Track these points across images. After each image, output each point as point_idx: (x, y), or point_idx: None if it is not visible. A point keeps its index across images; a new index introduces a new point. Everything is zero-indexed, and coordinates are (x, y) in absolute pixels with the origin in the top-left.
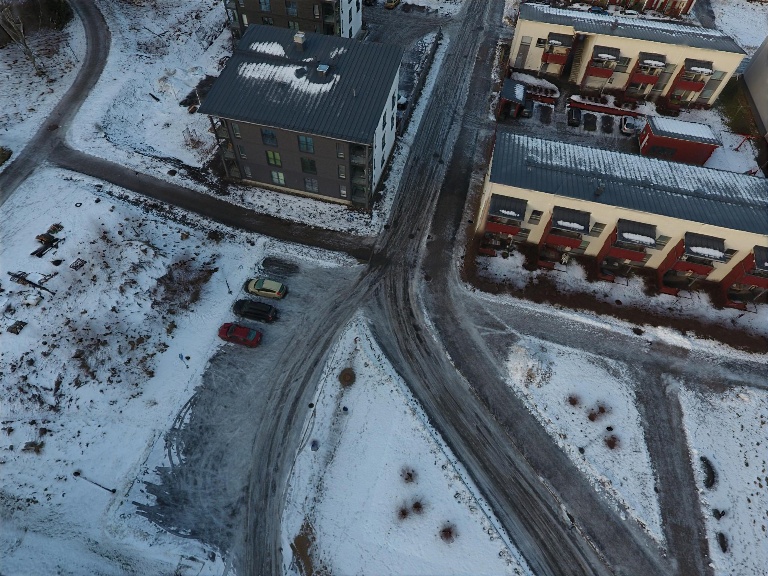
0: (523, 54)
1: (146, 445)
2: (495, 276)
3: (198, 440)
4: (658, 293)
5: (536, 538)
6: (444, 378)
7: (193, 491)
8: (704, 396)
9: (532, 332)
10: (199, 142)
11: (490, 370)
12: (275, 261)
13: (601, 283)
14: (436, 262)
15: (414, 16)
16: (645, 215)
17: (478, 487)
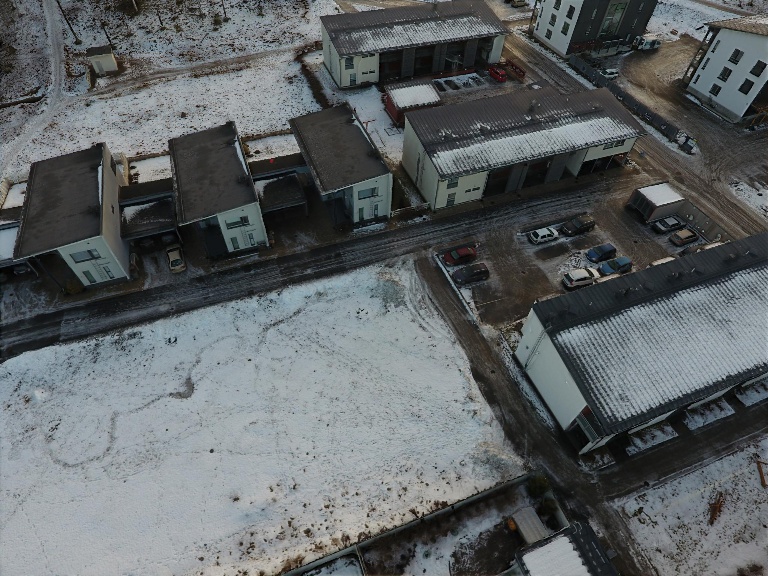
0: None
1: None
2: None
3: None
4: None
5: None
6: None
7: None
8: None
9: None
10: None
11: None
12: None
13: None
14: None
15: (749, 164)
16: None
17: None
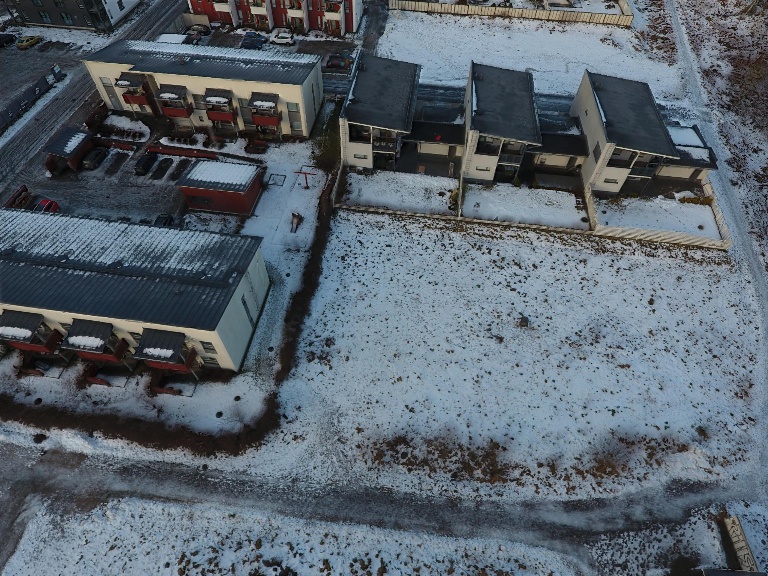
0: (113, 95)
1: None
2: None
3: None
4: (89, 384)
5: None
6: None
7: None
8: (61, 520)
9: None
10: None
11: None
12: None
13: (29, 378)
14: None
15: (47, 56)
16: None
17: None
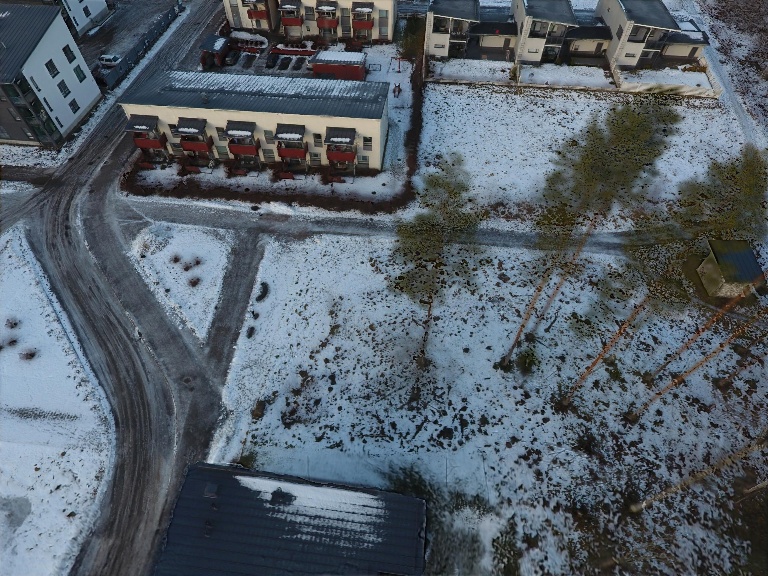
0: (236, 15)
1: None
2: (151, 183)
3: None
4: (280, 179)
5: (105, 350)
6: (76, 258)
7: None
8: (287, 244)
9: (165, 218)
10: None
11: (117, 248)
12: None
13: None
14: (103, 179)
15: None
16: (240, 114)
17: (72, 325)
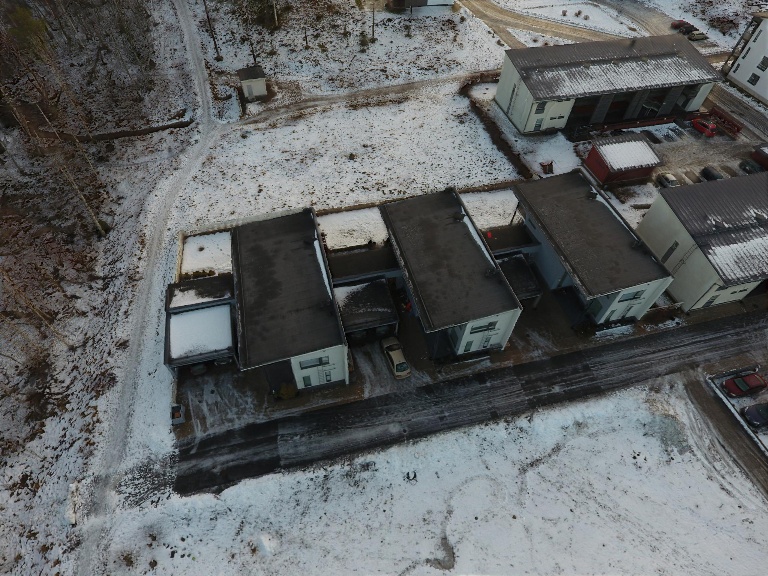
0: None
1: (659, 4)
2: None
3: (649, 9)
4: None
5: None
6: (603, 39)
7: (633, 4)
8: None
9: None
10: None
11: None
12: (713, 46)
13: None
14: None
15: None
16: None
17: None
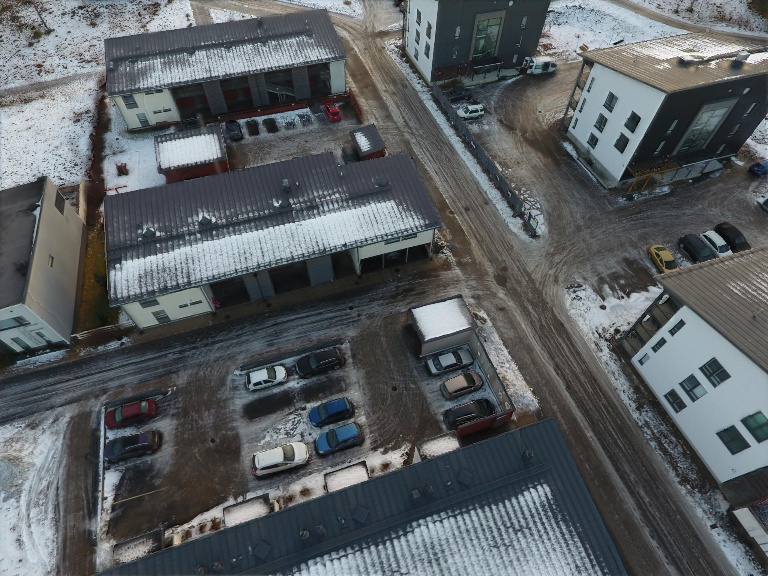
0: None
1: None
2: None
3: None
4: None
5: None
6: None
7: None
8: None
9: None
10: (542, 36)
11: None
12: None
13: None
14: (342, 44)
15: (606, 256)
16: None
17: None
